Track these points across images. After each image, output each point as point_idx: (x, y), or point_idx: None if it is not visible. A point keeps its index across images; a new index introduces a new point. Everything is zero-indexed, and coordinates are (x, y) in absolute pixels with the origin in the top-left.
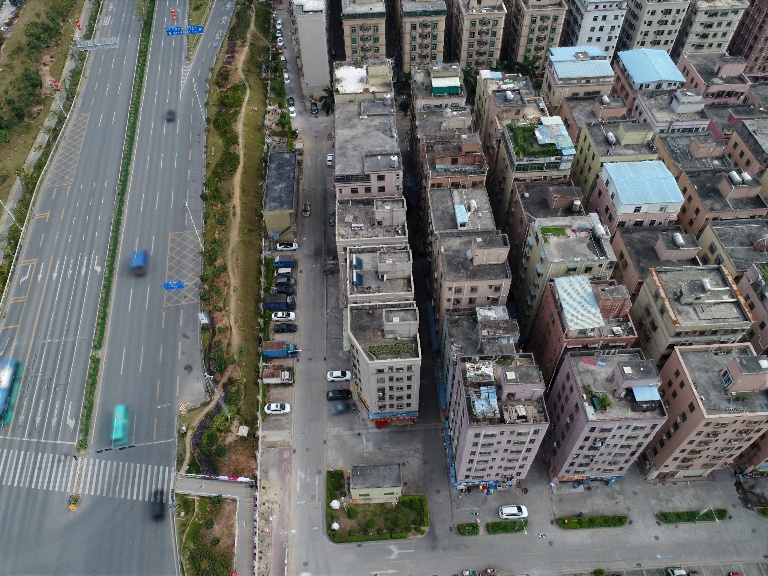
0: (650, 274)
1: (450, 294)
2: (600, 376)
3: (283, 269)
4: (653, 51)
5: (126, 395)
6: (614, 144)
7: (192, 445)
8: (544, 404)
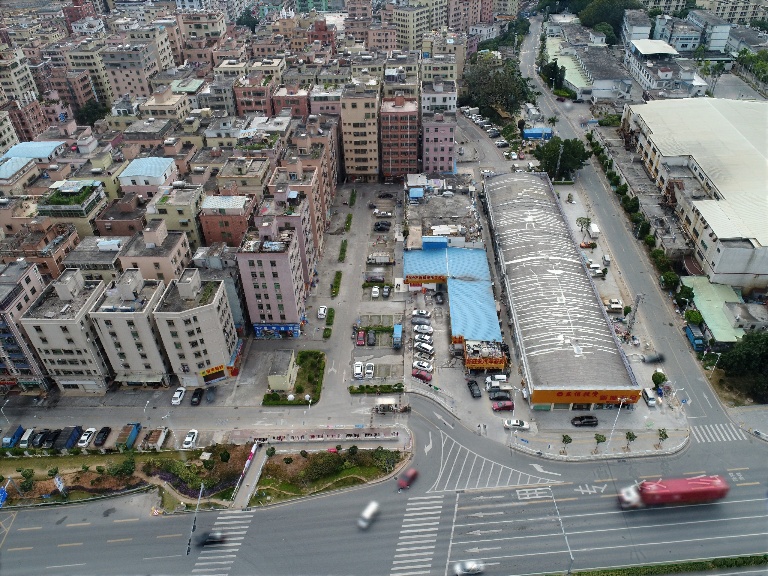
0: (219, 180)
1: (174, 267)
2: (273, 212)
3: (25, 435)
4: (20, 145)
5: (111, 574)
6: (102, 172)
7: (203, 497)
8: (284, 227)
